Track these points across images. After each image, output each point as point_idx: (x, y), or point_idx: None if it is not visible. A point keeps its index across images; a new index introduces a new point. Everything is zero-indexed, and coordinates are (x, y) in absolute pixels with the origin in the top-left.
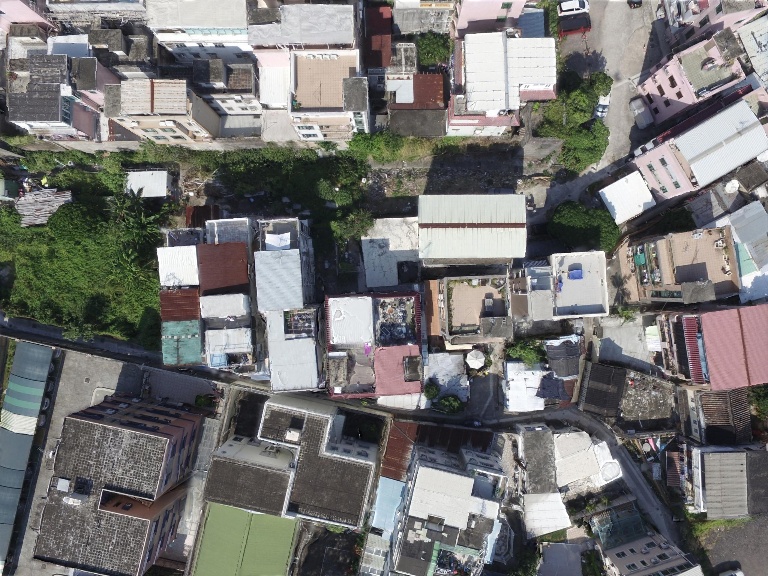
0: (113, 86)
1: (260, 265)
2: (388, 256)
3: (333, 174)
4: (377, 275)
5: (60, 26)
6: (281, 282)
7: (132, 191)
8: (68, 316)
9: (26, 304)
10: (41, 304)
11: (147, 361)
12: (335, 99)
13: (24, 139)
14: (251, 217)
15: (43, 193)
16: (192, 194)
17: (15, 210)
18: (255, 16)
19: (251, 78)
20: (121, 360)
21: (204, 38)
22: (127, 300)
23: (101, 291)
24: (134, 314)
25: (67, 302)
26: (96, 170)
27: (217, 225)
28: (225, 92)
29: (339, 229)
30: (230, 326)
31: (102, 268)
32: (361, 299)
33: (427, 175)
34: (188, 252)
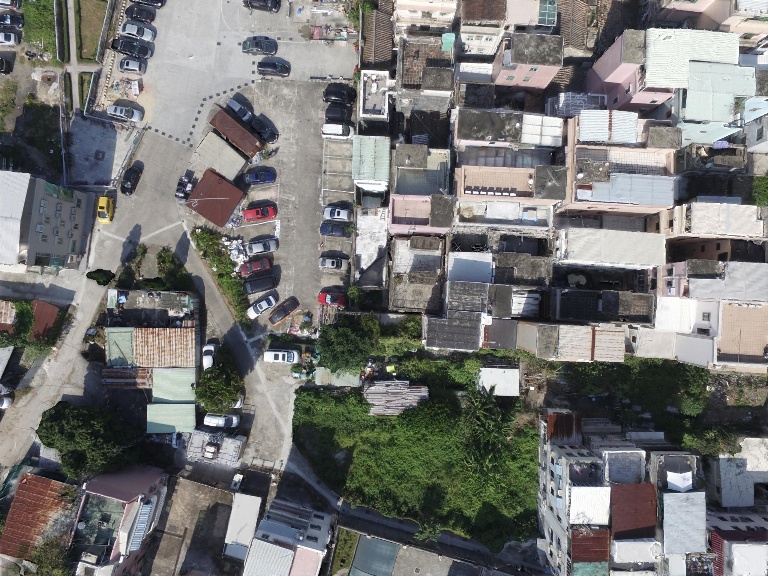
0: (547, 327)
1: (668, 508)
2: (745, 476)
3: (679, 381)
4: (733, 495)
5: (452, 235)
6: (686, 525)
7: (485, 388)
8: (406, 507)
9: (362, 490)
10: (380, 493)
11: (484, 558)
12: (754, 347)
13: (399, 340)
14: (608, 426)
15: (396, 385)
16: (533, 388)
17: (364, 399)
18: (694, 267)
19: (652, 308)
20: (469, 562)
21: (605, 264)
22: (463, 492)
23: (438, 482)
24: (472, 509)
25: (405, 492)
26: (435, 356)
27: (608, 453)
28: (625, 320)
29: (695, 444)
30: (636, 568)
31: (441, 459)
32: (756, 542)
33: (767, 385)
34: (597, 490)
